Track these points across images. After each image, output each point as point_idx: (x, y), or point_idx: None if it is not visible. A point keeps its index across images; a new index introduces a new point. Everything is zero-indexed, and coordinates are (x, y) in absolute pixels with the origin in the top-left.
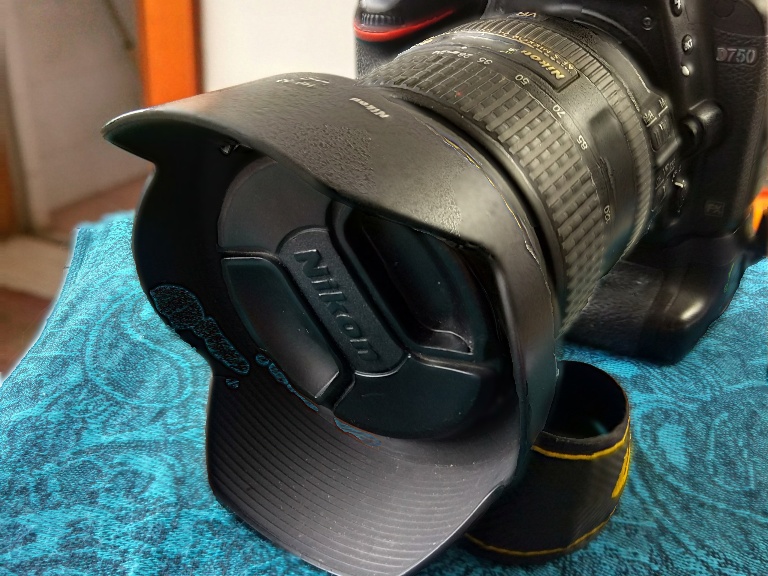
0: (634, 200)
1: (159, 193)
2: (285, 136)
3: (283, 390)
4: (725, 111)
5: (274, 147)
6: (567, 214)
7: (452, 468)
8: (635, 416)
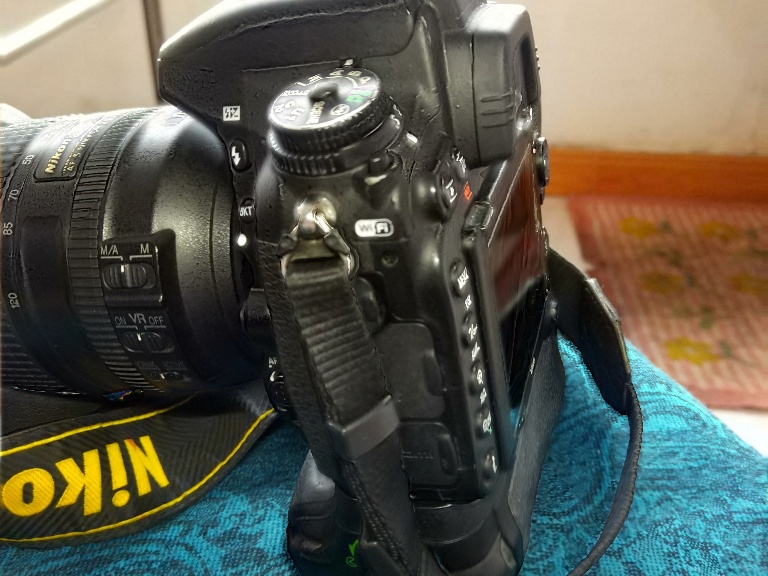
0: (76, 316)
1: None
2: None
3: None
4: None
5: None
6: None
7: None
8: (175, 554)
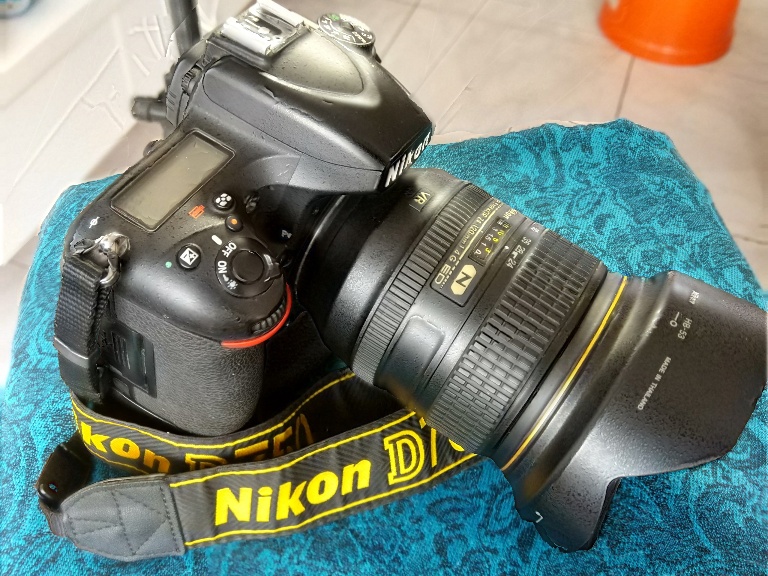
0: None
1: None
2: (763, 329)
3: None
4: None
5: None
6: None
7: None
8: None
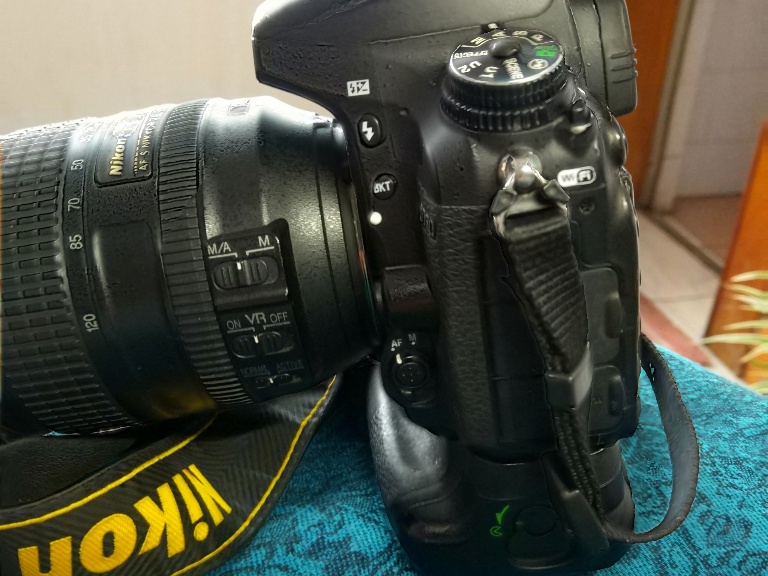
0: (173, 329)
1: None
2: None
3: None
4: (432, 289)
5: None
6: (1, 297)
7: None
8: None
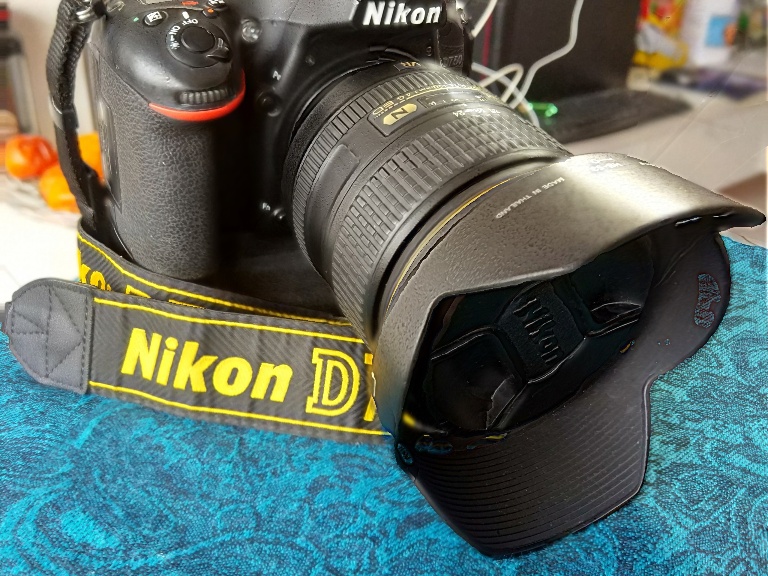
0: None
1: (431, 325)
2: (725, 199)
3: (428, 454)
4: None
5: (746, 207)
6: None
7: (567, 407)
8: None
